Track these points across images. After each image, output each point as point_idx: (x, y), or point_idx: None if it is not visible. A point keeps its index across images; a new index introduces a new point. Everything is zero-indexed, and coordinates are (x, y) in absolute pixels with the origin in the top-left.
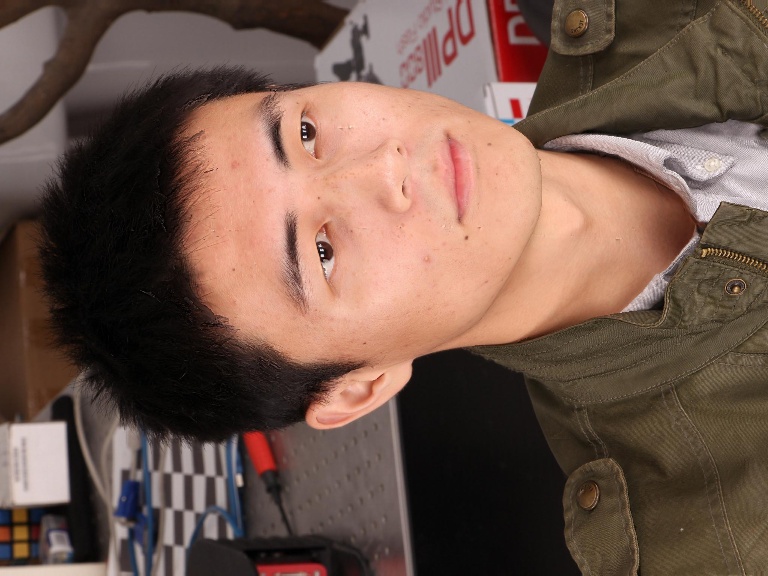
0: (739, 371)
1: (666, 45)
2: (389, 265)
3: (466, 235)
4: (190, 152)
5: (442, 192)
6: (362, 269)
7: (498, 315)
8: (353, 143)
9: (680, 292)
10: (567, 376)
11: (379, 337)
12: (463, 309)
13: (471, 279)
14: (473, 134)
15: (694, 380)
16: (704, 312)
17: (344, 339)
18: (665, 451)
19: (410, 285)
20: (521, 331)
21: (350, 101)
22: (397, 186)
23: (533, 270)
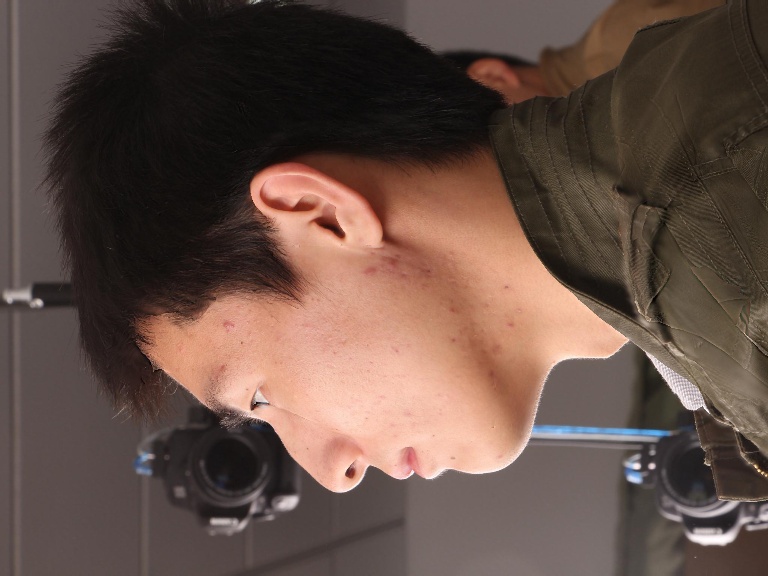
0: None
1: (696, 384)
2: None
3: None
4: (151, 362)
5: None
6: None
7: None
8: (310, 423)
9: None
10: None
11: None
12: None
13: None
14: (435, 450)
15: None
16: None
17: None
18: None
19: None
20: None
21: (300, 409)
22: None
23: None
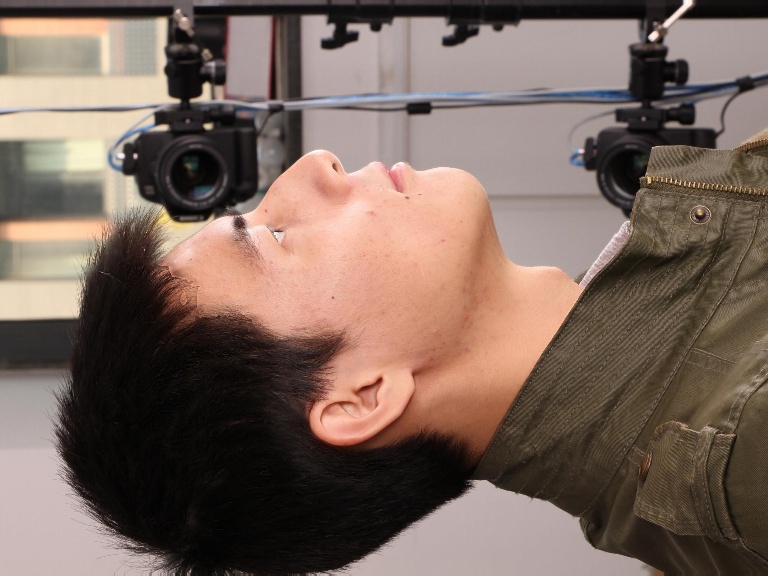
0: (747, 302)
1: None
2: (334, 219)
3: (406, 196)
4: None
5: (374, 171)
6: (310, 229)
7: (496, 341)
8: None
9: (646, 228)
10: (597, 404)
11: (345, 289)
12: (426, 263)
13: (425, 235)
14: None
15: (708, 329)
16: (676, 236)
17: (310, 295)
18: (705, 396)
19: (358, 229)
20: (529, 361)
21: None
22: (325, 161)
23: (517, 298)
